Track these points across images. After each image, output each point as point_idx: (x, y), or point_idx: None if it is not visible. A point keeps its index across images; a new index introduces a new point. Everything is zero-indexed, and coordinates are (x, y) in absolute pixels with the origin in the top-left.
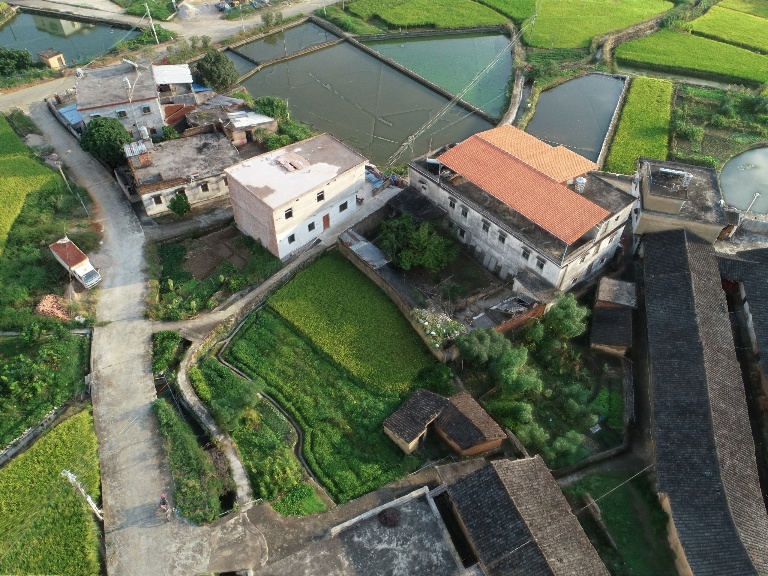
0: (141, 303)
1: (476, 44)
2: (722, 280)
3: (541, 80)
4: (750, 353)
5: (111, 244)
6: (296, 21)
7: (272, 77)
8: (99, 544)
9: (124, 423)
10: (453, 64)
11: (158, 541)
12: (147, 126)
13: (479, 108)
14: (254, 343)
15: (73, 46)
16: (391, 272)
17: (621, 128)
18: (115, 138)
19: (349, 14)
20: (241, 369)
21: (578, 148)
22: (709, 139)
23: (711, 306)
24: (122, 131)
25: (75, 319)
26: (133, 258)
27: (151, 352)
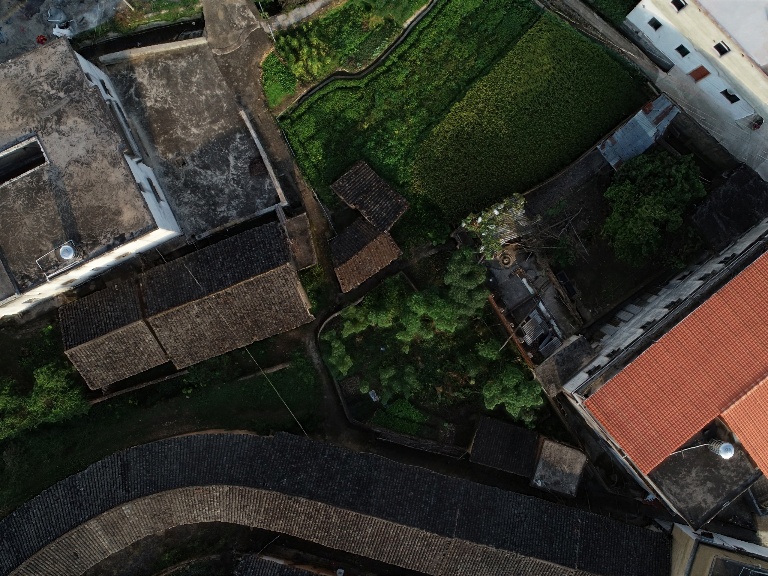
0: None
1: None
2: None
3: None
4: None
5: None
6: None
7: None
8: None
9: None
10: None
11: None
12: None
13: None
14: (482, 5)
15: None
16: None
17: None
18: None
19: None
20: None
21: None
22: None
23: (520, 575)
24: None
25: None
26: None
27: None
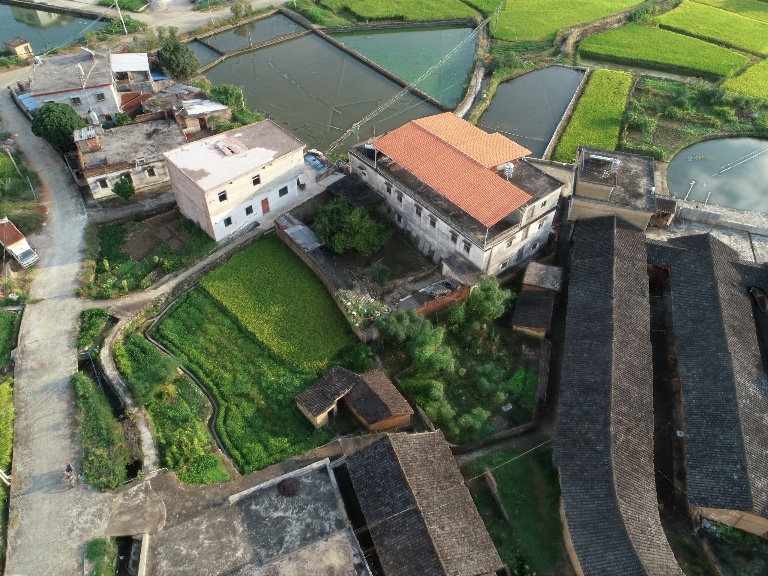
0: (75, 282)
1: (442, 36)
2: (654, 267)
3: (500, 71)
4: (671, 337)
5: (54, 226)
6: (266, 13)
7: (239, 68)
8: (3, 508)
9: (42, 395)
10: (416, 56)
11: (60, 506)
12: (102, 113)
13: (430, 97)
14: (182, 321)
15: (40, 35)
16: (326, 255)
17: (574, 119)
18: (66, 123)
19: (320, 6)
20: (166, 346)
21: (529, 138)
22: (662, 130)
23: (631, 290)
24: (73, 117)
25: (8, 296)
26: (73, 239)
27: (78, 328)
